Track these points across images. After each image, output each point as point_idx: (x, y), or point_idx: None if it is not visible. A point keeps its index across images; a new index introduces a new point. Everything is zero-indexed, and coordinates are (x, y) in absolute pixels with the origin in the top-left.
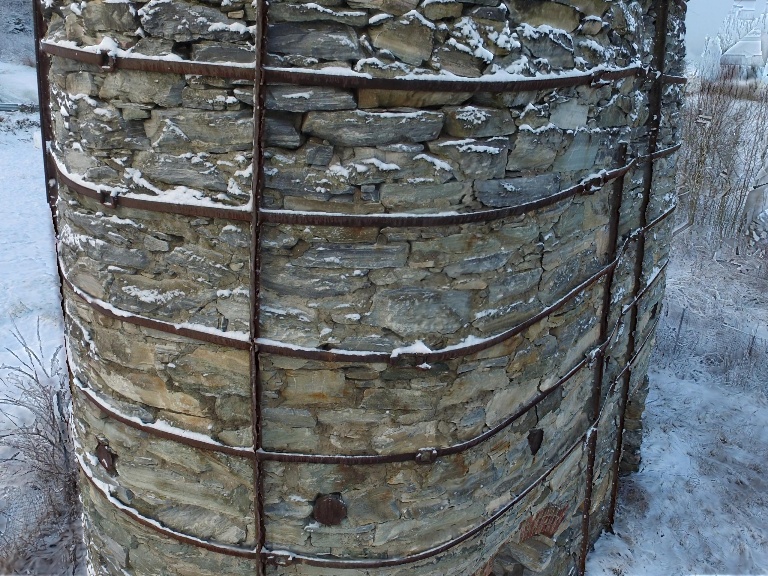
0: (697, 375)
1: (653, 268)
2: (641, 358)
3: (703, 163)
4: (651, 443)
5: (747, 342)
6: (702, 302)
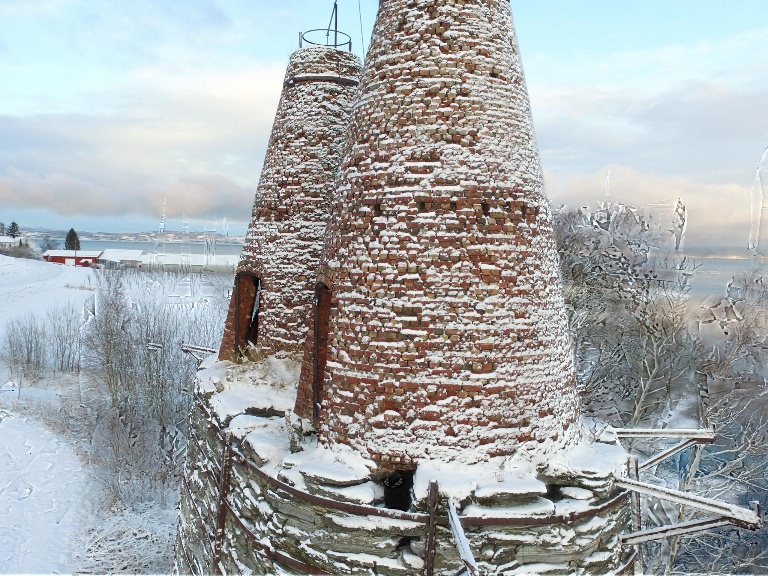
0: None
1: None
2: None
3: (164, 384)
4: None
5: None
6: None
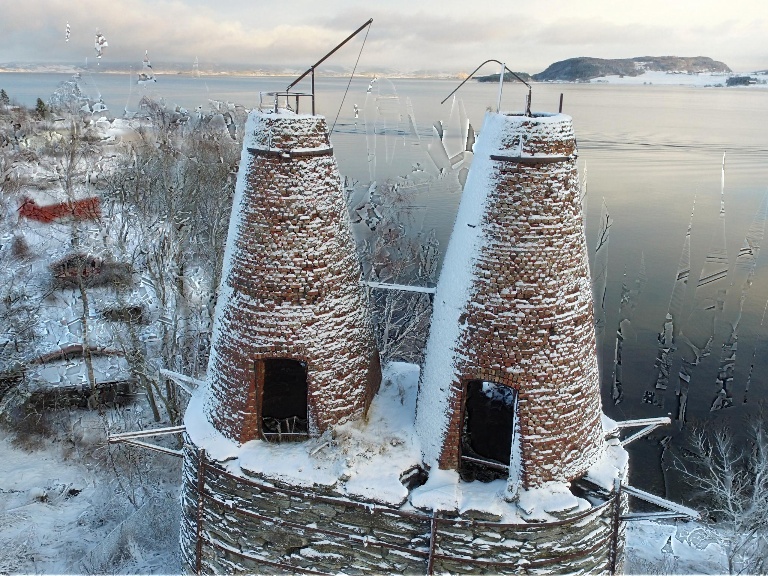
0: (137, 575)
1: None
2: None
3: None
4: None
5: None
6: (6, 551)
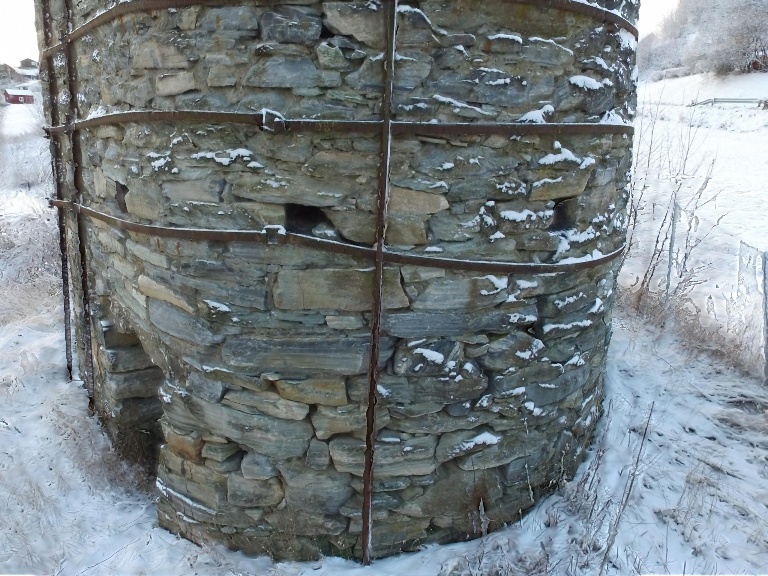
0: None
1: (101, 106)
2: (114, 254)
3: None
4: (177, 560)
5: None
6: None
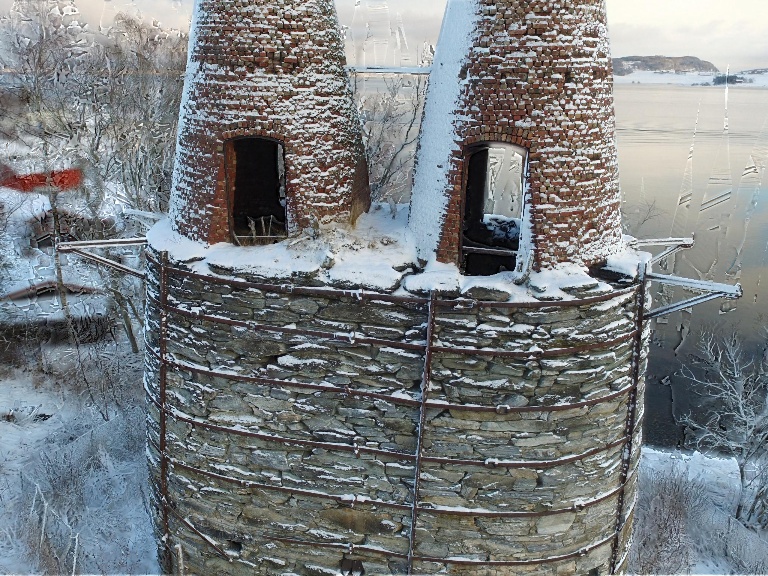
0: None
1: None
2: None
3: None
4: None
5: (89, 439)
6: None
